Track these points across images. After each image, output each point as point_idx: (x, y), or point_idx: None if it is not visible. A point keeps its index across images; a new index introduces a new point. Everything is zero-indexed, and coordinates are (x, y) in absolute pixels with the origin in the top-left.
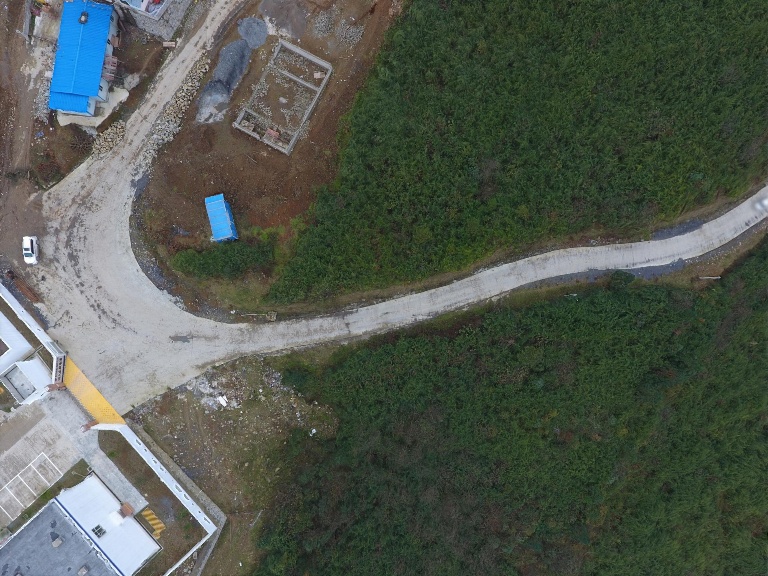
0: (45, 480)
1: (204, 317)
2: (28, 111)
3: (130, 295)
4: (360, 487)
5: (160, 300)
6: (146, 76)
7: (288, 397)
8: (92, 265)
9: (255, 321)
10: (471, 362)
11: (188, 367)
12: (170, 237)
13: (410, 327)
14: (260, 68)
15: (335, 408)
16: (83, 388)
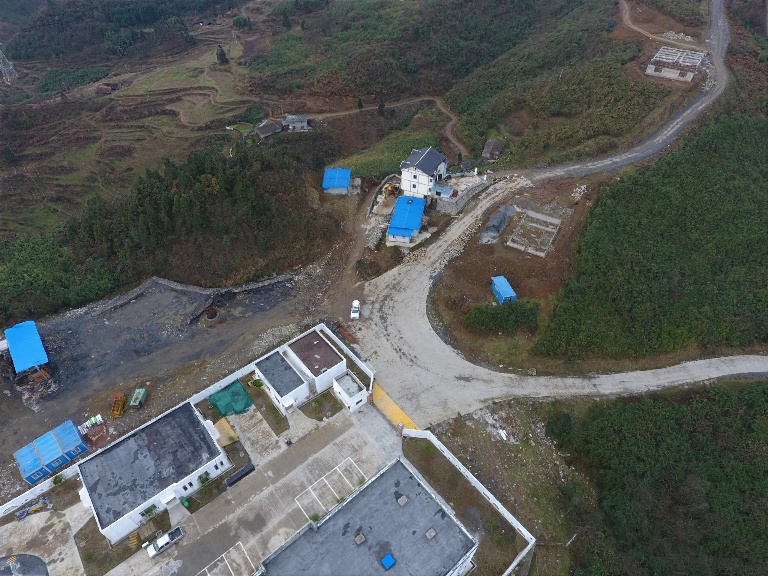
0: (349, 484)
1: (480, 366)
2: (362, 243)
3: (424, 345)
4: (644, 571)
5: (446, 351)
6: (441, 228)
7: (551, 452)
8: (397, 323)
9: (520, 374)
10: (710, 434)
11: (472, 400)
12: (461, 304)
13: (646, 395)
14: (515, 223)
15: (594, 473)
16: (388, 405)
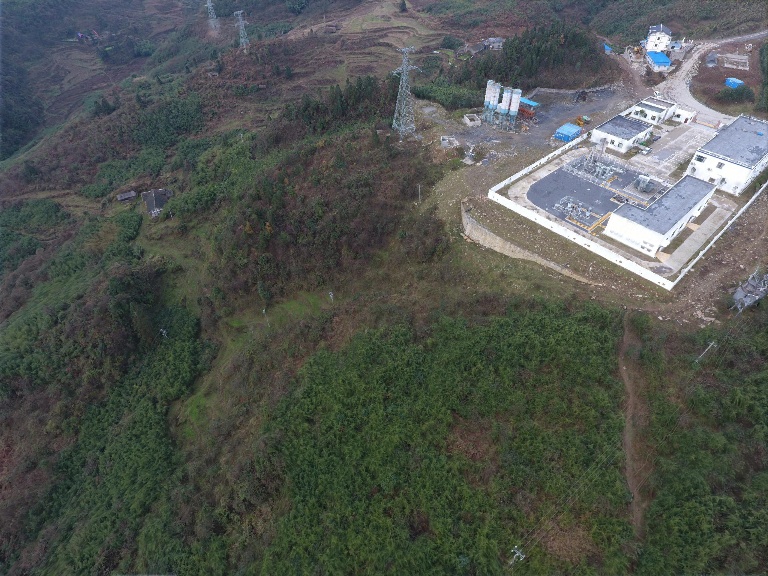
0: None
1: None
2: None
3: None
4: None
5: (711, 110)
6: None
7: None
8: None
9: None
10: None
11: None
12: None
13: None
14: None
15: None
16: None
